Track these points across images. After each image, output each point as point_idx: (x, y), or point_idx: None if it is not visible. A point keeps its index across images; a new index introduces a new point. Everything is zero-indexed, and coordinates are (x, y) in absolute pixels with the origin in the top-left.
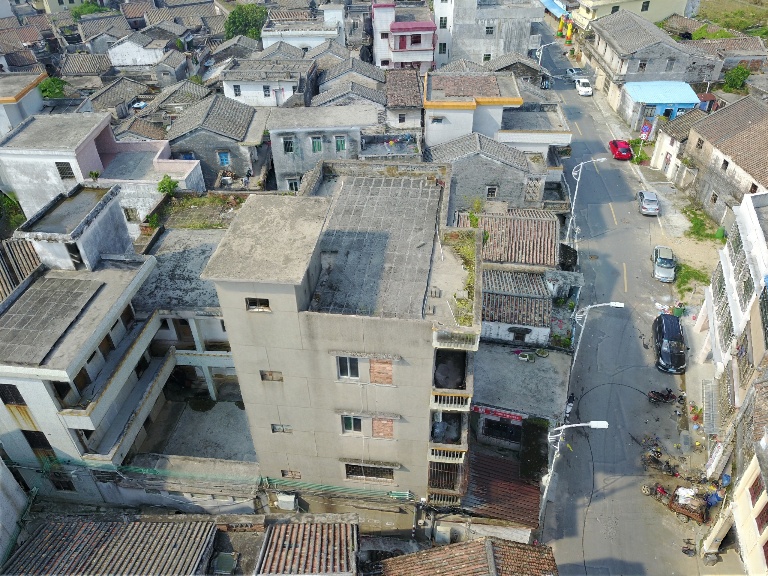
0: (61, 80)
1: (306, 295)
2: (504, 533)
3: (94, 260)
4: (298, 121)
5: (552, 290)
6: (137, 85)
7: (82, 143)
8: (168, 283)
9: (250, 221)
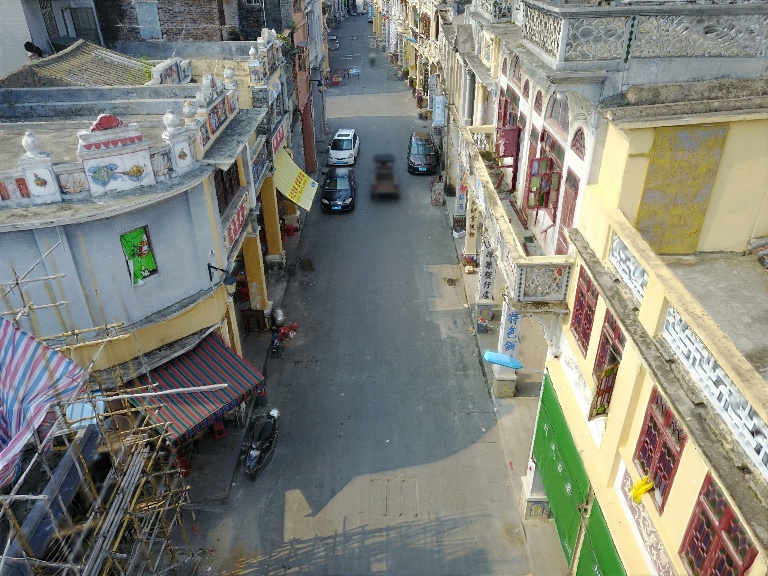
0: None
1: None
2: (357, 2)
3: None
4: None
5: None
6: None
7: None
8: None
9: None
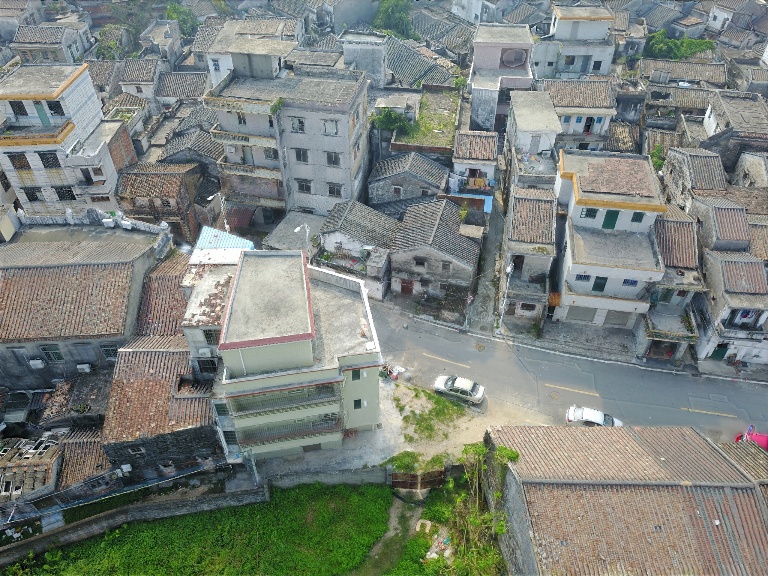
0: (714, 45)
1: (246, 70)
2: None
3: (348, 60)
4: (521, 101)
5: (364, 248)
6: (722, 75)
7: (484, 43)
8: (367, 99)
9: (274, 42)
